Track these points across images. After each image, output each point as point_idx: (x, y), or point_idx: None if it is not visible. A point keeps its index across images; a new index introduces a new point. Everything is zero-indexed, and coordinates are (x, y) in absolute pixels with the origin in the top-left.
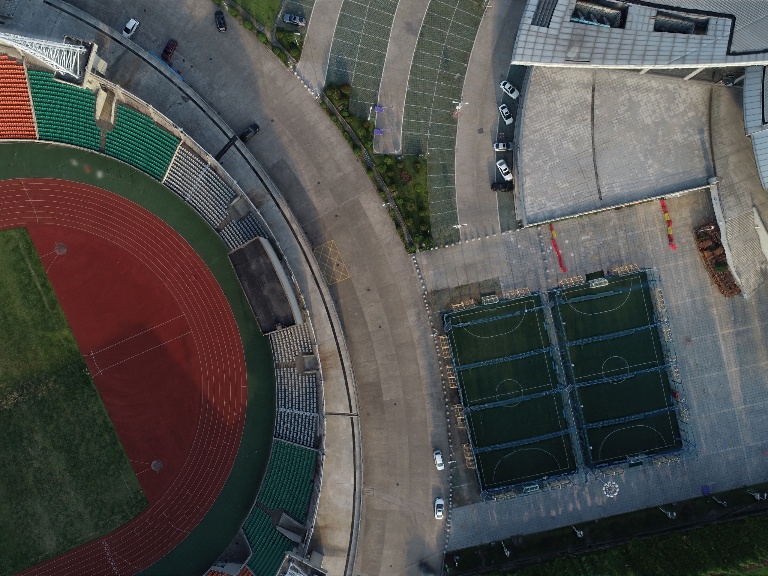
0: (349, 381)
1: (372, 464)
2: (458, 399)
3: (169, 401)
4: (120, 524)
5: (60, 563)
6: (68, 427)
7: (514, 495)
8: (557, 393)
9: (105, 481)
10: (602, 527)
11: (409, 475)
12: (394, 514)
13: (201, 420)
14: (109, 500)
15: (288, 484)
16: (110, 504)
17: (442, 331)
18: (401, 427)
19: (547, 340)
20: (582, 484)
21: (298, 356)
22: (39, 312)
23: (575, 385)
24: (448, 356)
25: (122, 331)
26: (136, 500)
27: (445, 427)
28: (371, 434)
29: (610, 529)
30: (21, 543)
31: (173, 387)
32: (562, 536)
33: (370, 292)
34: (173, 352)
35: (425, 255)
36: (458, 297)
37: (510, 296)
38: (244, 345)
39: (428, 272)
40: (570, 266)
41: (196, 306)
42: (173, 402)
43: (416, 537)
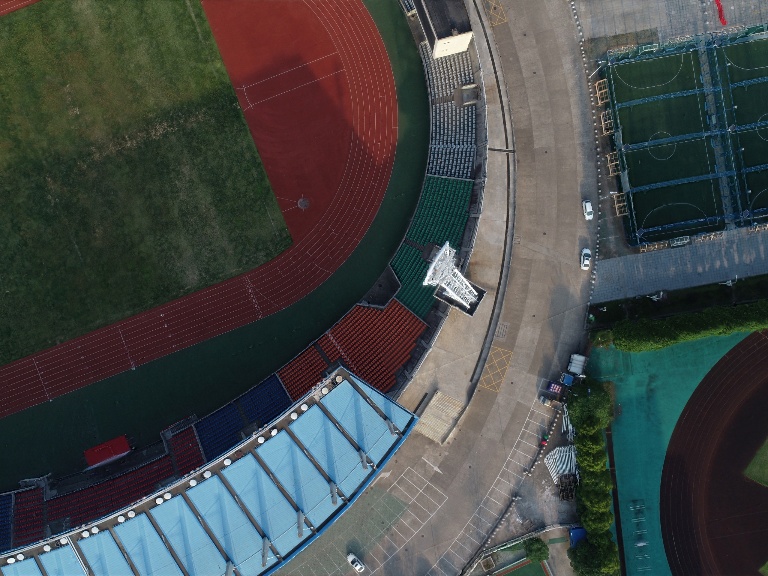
0: (507, 117)
1: (520, 212)
2: (610, 150)
3: (319, 139)
4: (263, 261)
5: (201, 298)
6: (216, 160)
7: (665, 244)
8: (710, 148)
9: (250, 217)
10: (749, 285)
11: (556, 225)
12: (539, 263)
13: (350, 160)
14: (254, 236)
15: (440, 218)
16: (254, 240)
17: (597, 80)
18: (551, 176)
19: (703, 94)
20: (730, 241)
21: (457, 89)
22: (192, 43)
23: (736, 128)
24: (605, 100)
25: (275, 66)
26: (281, 238)
27: (595, 178)
28: (520, 181)
29: (757, 287)
30: (163, 276)
31: (323, 125)
32: (708, 292)
33: (526, 37)
34: (325, 89)
35: (584, 2)
36: (615, 46)
37: (671, 41)
38: (397, 85)
39: (586, 19)
40: (730, 19)
41: (350, 44)
42: (322, 140)
43: (560, 288)
